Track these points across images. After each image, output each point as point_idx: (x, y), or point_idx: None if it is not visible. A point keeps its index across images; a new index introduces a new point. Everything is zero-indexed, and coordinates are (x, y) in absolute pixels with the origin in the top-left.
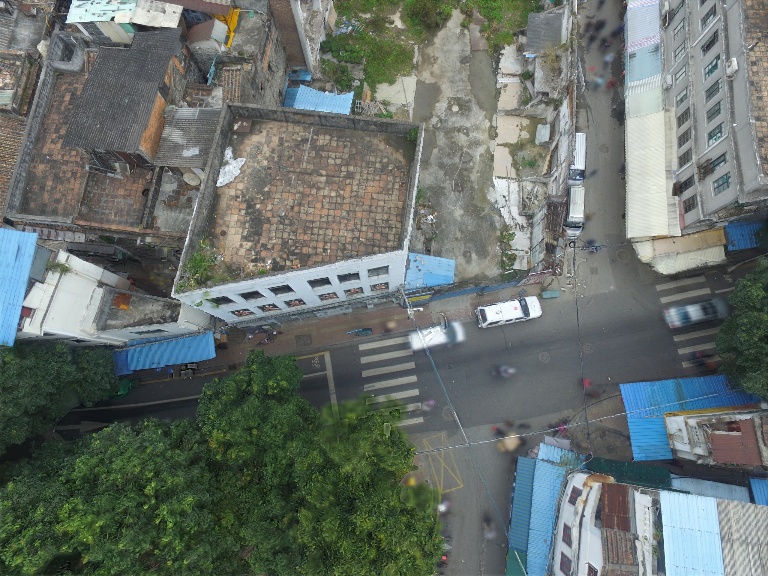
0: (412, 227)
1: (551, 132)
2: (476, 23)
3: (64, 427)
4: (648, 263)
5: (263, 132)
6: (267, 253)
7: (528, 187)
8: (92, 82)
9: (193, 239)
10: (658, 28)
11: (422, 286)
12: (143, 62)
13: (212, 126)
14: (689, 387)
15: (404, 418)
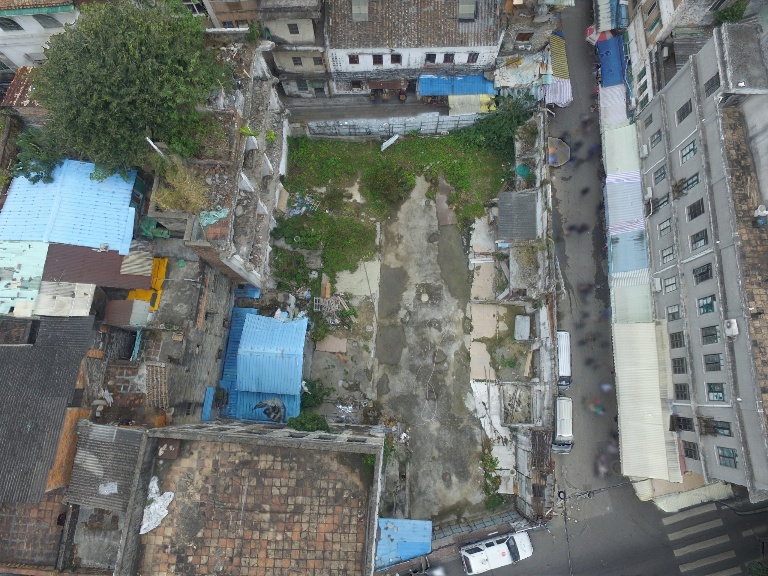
0: (381, 480)
1: (531, 322)
2: (442, 192)
3: None
4: None
5: (194, 454)
6: None
7: (509, 391)
8: None
9: None
10: (641, 212)
11: (396, 560)
12: (49, 366)
13: (132, 454)
14: None
15: None
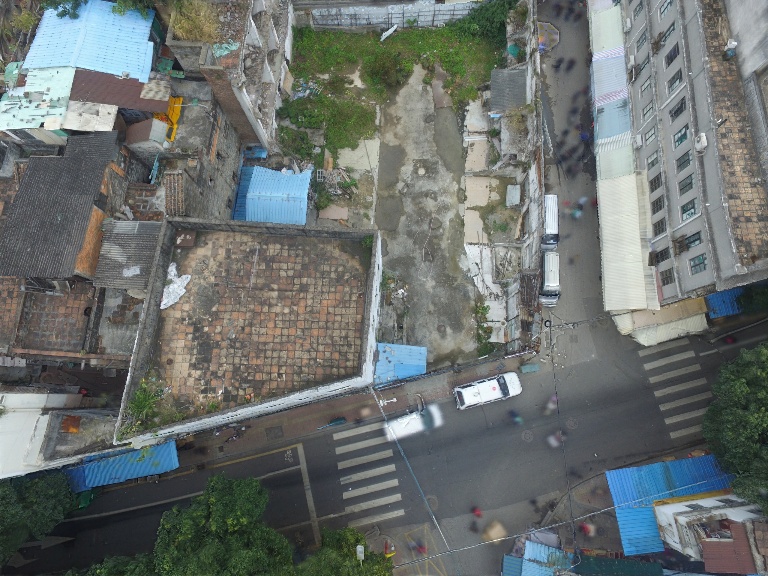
0: (380, 313)
1: (522, 192)
2: (439, 78)
3: (24, 544)
4: (628, 334)
5: (209, 244)
6: (218, 382)
7: (501, 253)
8: (21, 199)
9: (135, 375)
10: (625, 82)
11: (393, 379)
12: (77, 172)
13: (153, 242)
14: (677, 470)
15: (384, 512)
